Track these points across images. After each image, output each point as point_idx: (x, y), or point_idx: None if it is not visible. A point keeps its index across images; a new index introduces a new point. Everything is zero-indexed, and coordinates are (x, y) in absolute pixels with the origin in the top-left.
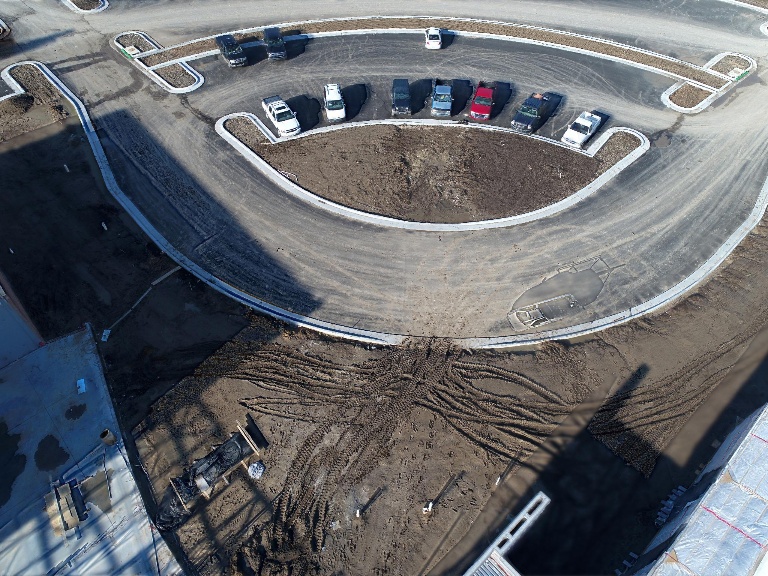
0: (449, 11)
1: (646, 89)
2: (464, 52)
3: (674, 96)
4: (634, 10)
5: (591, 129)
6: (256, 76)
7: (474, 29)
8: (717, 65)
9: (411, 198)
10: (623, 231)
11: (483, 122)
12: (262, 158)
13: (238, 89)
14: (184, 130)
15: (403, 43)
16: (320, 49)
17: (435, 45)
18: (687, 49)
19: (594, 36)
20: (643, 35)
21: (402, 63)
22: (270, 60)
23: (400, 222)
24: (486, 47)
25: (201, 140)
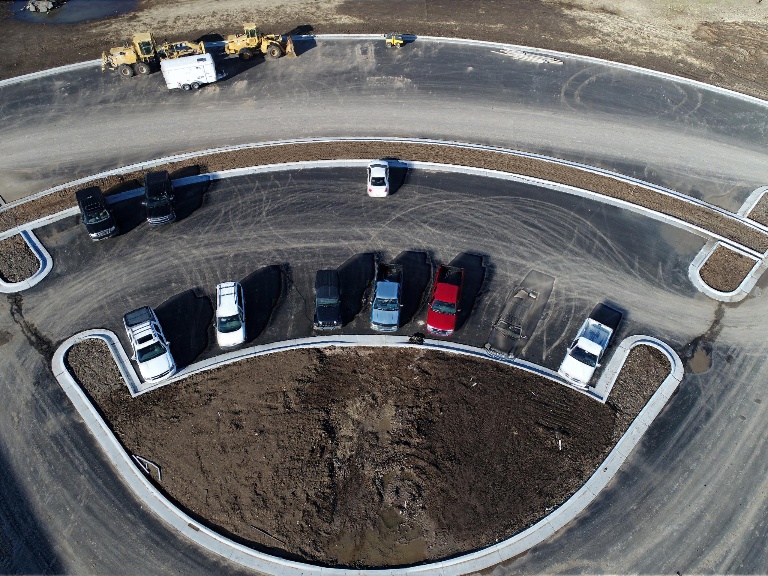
0: (401, 127)
1: (667, 258)
2: (419, 199)
3: (706, 270)
4: (638, 118)
5: (600, 354)
6: (128, 255)
7: (433, 157)
8: (755, 210)
9: (335, 509)
10: (663, 569)
11: (445, 337)
12: (112, 429)
13: (98, 281)
14: (4, 370)
15: (338, 185)
16: (224, 200)
17: (380, 193)
18: (712, 183)
19: (590, 164)
20: (653, 160)
21: (334, 223)
22: (150, 225)
23: (314, 571)
24: (449, 189)
25: (26, 391)
